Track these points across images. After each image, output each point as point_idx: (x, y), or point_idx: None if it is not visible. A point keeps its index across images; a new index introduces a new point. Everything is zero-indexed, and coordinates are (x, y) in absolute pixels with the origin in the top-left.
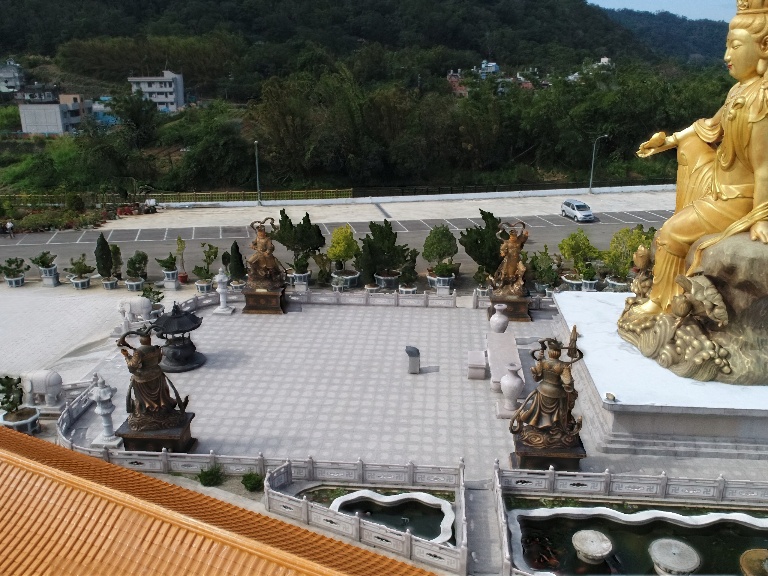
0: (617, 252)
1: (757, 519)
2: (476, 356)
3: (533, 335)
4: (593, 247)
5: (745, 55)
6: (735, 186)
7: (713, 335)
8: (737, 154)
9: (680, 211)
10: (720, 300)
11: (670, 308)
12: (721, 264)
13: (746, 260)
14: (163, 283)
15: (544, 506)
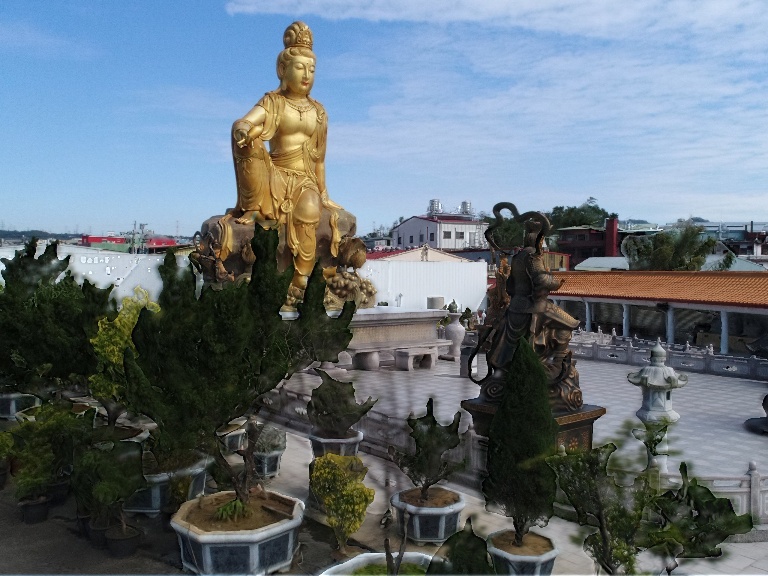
0: None
1: None
2: (415, 349)
3: None
4: None
5: None
6: None
7: None
8: None
9: None
10: None
11: None
12: None
13: None
14: None
15: None
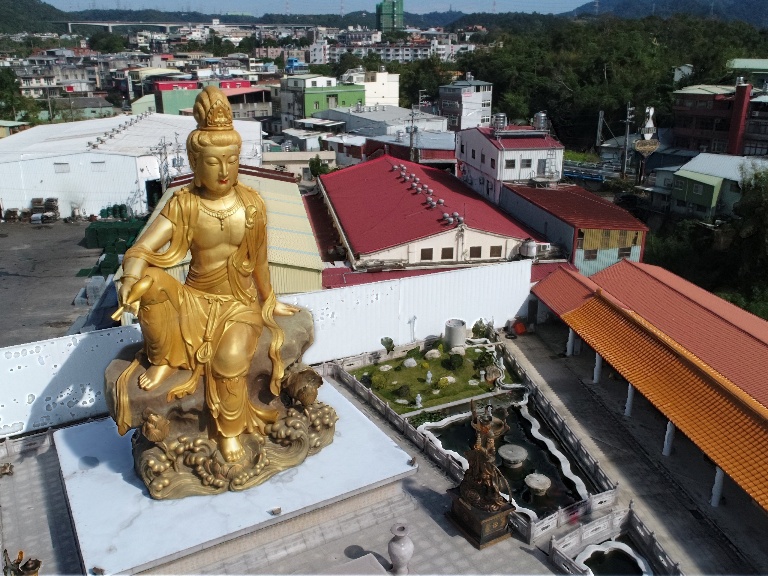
0: None
1: (433, 439)
2: None
3: None
4: None
5: None
6: None
7: None
8: None
9: (231, 335)
10: None
11: None
12: None
13: None
14: None
15: None
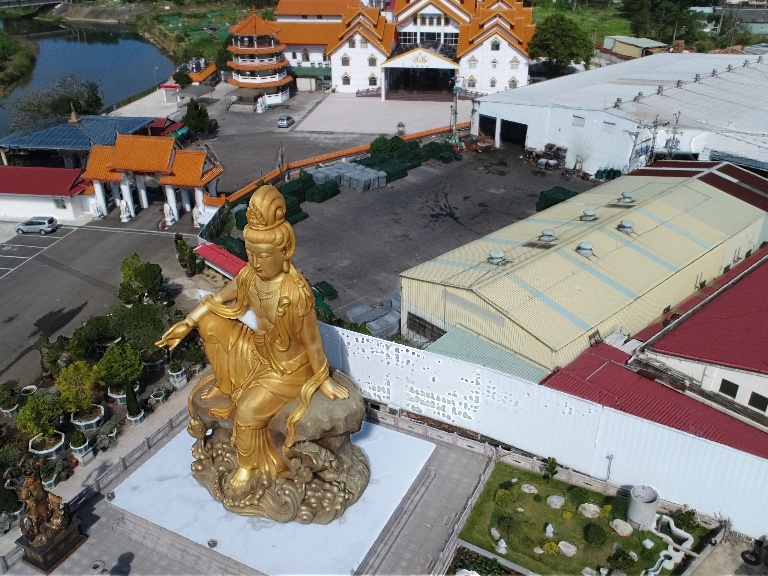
0: (72, 393)
1: None
2: None
3: (116, 556)
4: (48, 403)
5: (275, 263)
6: (294, 360)
7: (324, 475)
8: (291, 338)
9: (250, 393)
10: (331, 454)
11: (280, 474)
12: (323, 430)
13: (343, 420)
14: None
15: None
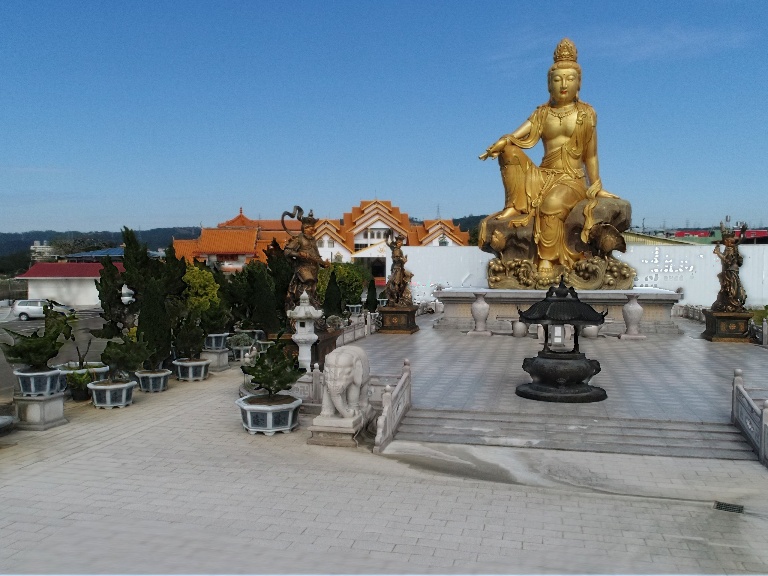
0: None
1: None
2: None
3: None
4: None
5: None
6: None
7: None
8: None
9: (555, 190)
10: None
11: None
12: (615, 212)
13: None
14: (8, 419)
15: None
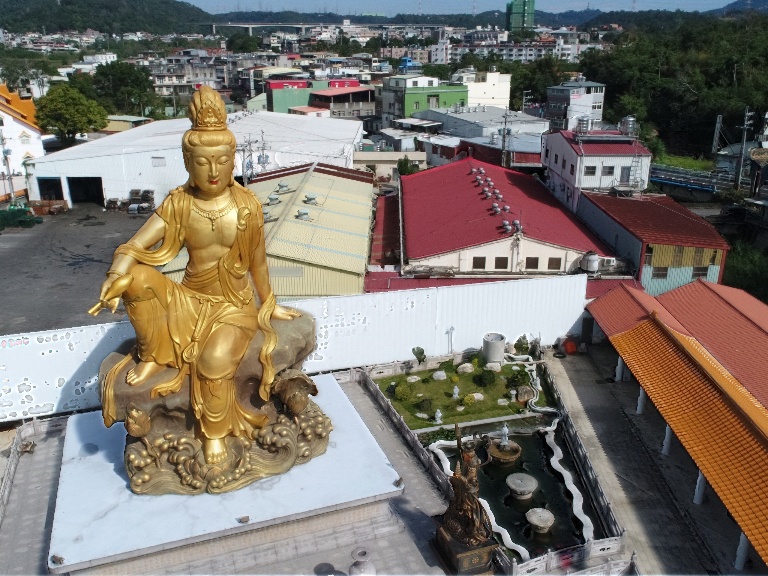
0: None
1: None
2: None
3: None
4: None
5: None
6: None
7: None
8: None
9: (217, 337)
10: None
11: None
12: None
13: None
14: None
15: (506, 555)
